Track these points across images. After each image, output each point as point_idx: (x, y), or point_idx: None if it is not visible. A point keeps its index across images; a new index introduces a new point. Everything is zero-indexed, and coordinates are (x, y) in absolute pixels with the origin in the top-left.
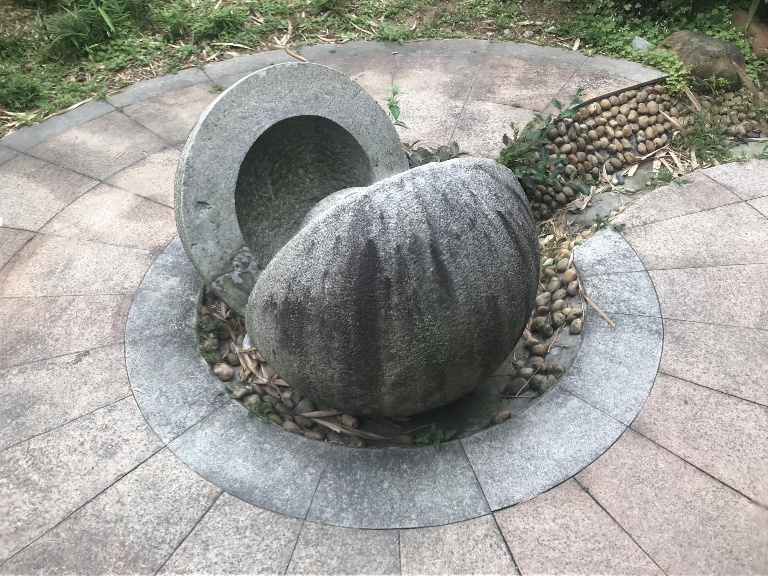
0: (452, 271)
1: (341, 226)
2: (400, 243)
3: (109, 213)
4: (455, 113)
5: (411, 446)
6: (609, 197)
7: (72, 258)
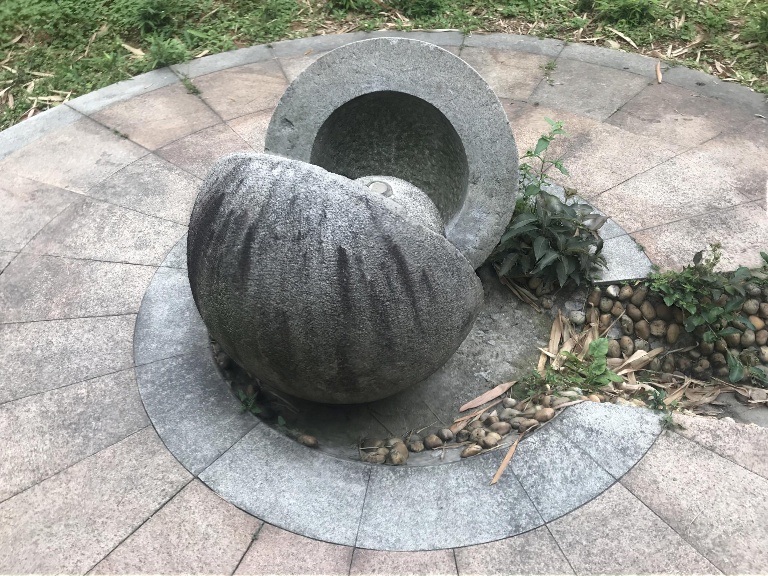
0: (253, 261)
1: (225, 171)
2: (234, 210)
3: None
4: (715, 205)
5: (237, 394)
6: None
7: None
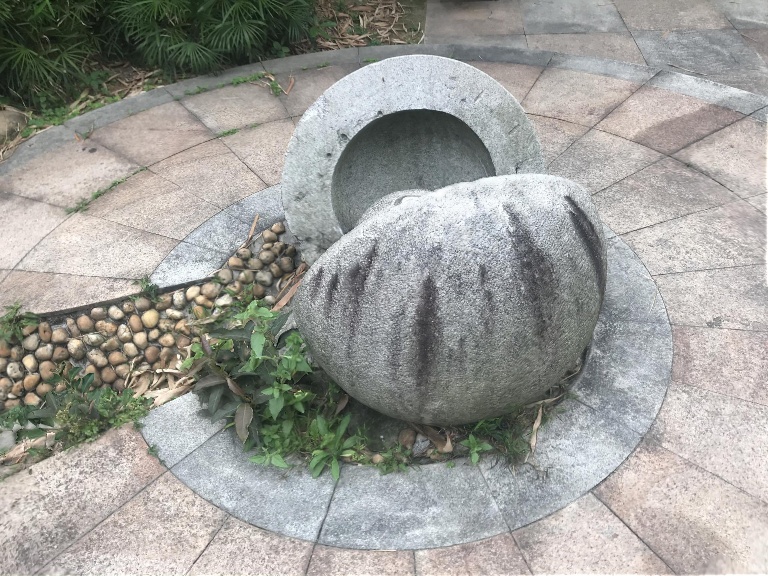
0: None
1: None
2: None
3: (757, 569)
4: None
5: None
6: (4, 442)
7: None
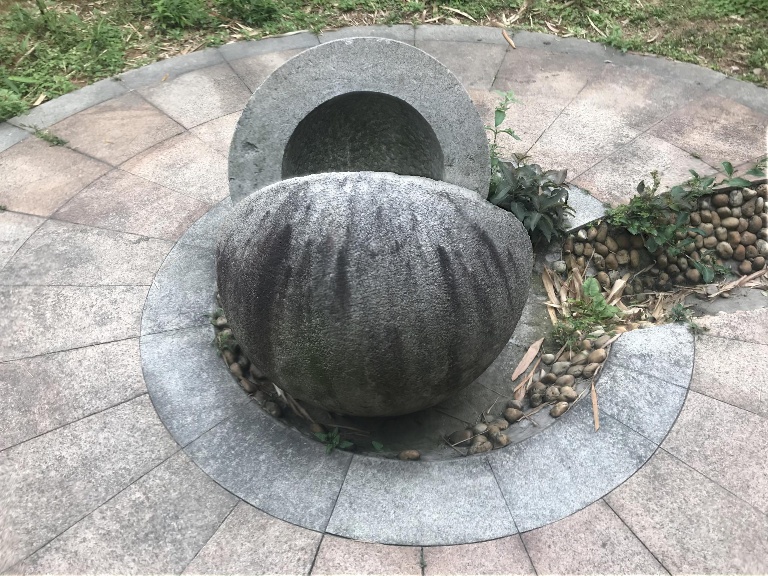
0: (353, 285)
1: (275, 202)
2: (312, 238)
3: None
4: (619, 142)
5: (311, 437)
6: (758, 296)
7: (194, 160)
